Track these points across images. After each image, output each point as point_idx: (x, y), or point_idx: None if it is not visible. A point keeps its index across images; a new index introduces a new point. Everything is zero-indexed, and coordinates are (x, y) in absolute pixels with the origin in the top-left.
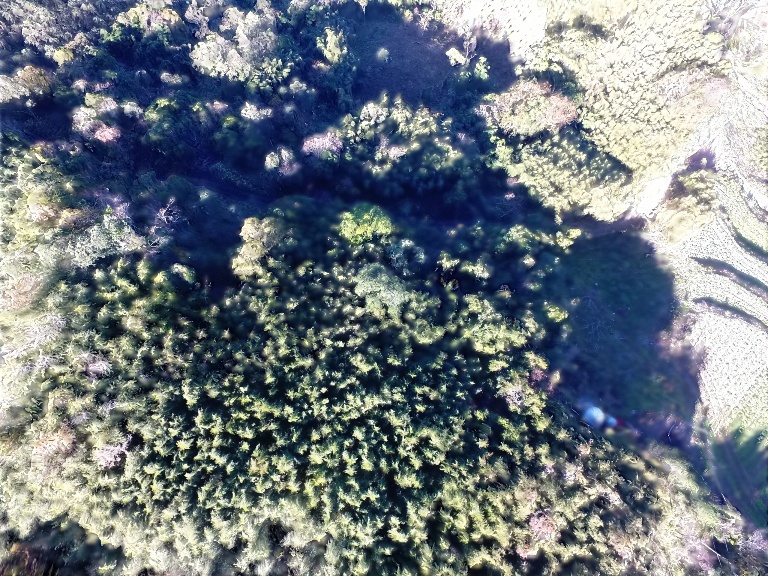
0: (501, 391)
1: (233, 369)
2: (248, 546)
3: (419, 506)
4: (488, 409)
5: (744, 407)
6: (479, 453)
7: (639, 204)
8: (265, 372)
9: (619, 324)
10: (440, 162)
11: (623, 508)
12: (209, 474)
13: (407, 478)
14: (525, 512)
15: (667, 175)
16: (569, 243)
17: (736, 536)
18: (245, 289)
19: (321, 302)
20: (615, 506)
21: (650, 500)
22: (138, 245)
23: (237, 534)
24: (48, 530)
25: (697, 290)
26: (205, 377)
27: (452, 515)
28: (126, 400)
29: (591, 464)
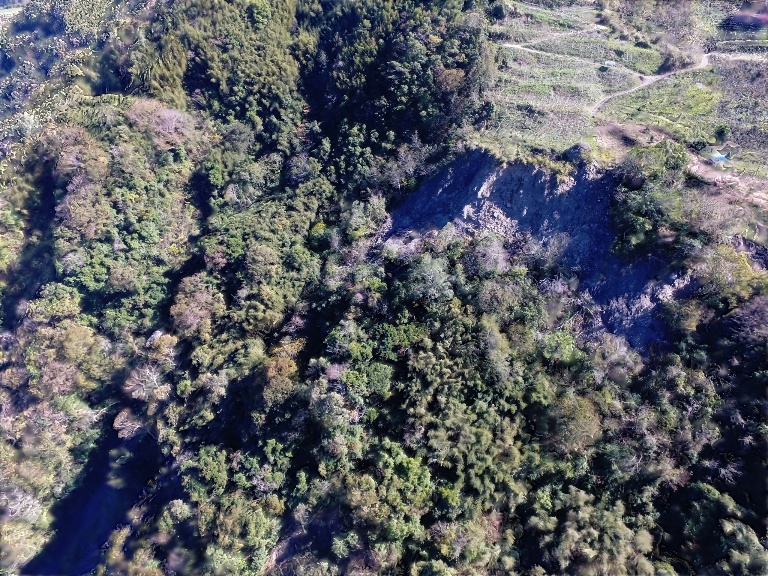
0: None
1: None
2: None
3: None
4: None
5: None
6: None
7: None
8: None
9: None
10: None
11: None
12: None
13: None
14: None
15: None
16: None
17: None
18: (50, 4)
19: None
20: None
21: None
22: None
23: None
24: None
25: (3, 22)
26: None
27: None
28: None
29: None
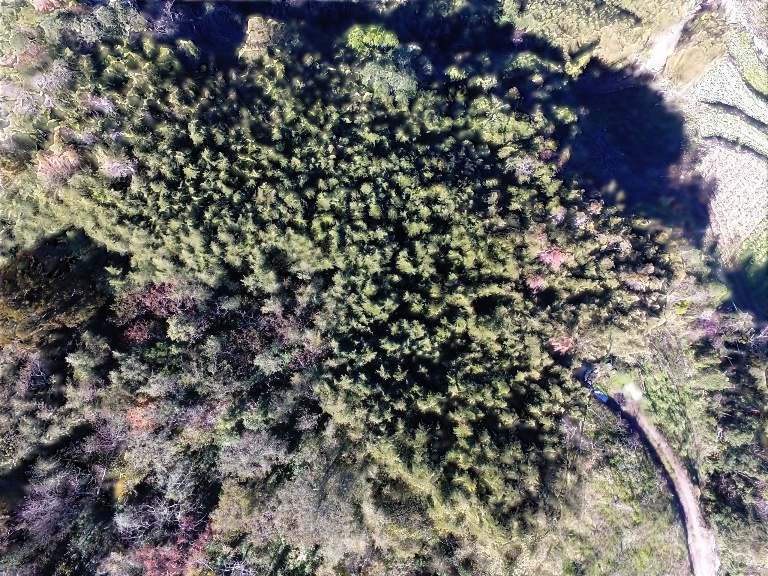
0: (510, 165)
1: (240, 123)
2: (255, 265)
3: (428, 243)
4: (497, 179)
5: (755, 240)
6: (488, 205)
7: (648, 62)
8: (272, 132)
9: (628, 162)
10: (447, 9)
11: (635, 259)
12: (216, 200)
13: (415, 223)
14: (535, 251)
15: (677, 20)
16: (578, 72)
17: (748, 332)
18: (252, 70)
19: (328, 90)
20: (626, 256)
21: (662, 257)
22: (144, 27)
23: (244, 256)
24: (53, 243)
25: (707, 129)
26: (211, 126)
27: (461, 253)
28: (132, 134)
29: (602, 224)
